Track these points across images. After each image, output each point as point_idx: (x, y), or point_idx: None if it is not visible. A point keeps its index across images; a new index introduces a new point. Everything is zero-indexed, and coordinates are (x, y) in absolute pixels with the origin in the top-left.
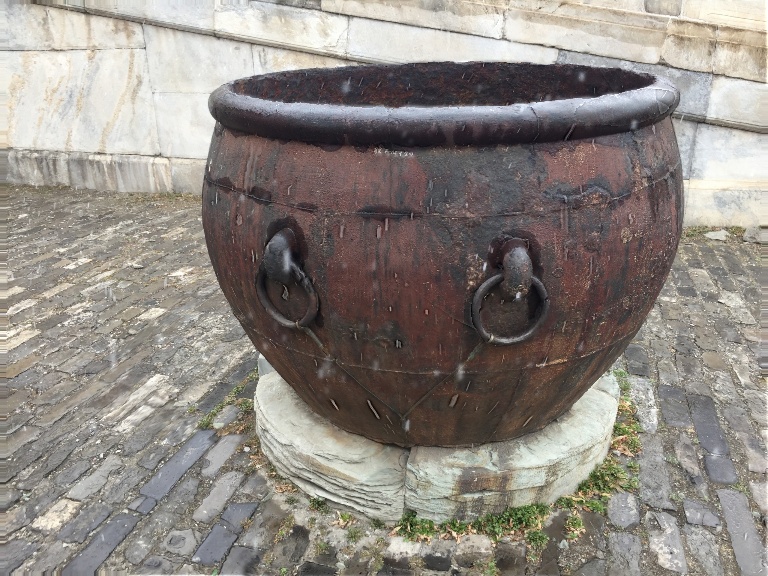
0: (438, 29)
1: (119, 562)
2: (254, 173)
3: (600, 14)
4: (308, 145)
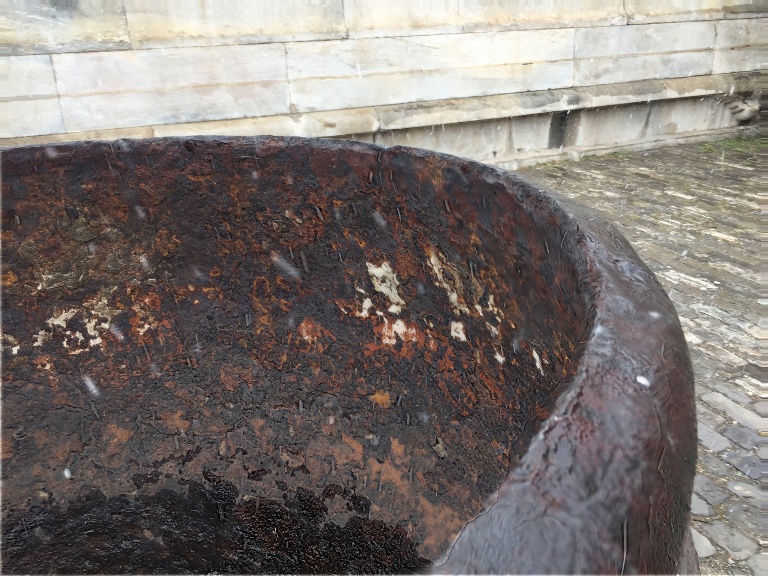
0: None
1: None
2: None
3: None
4: None
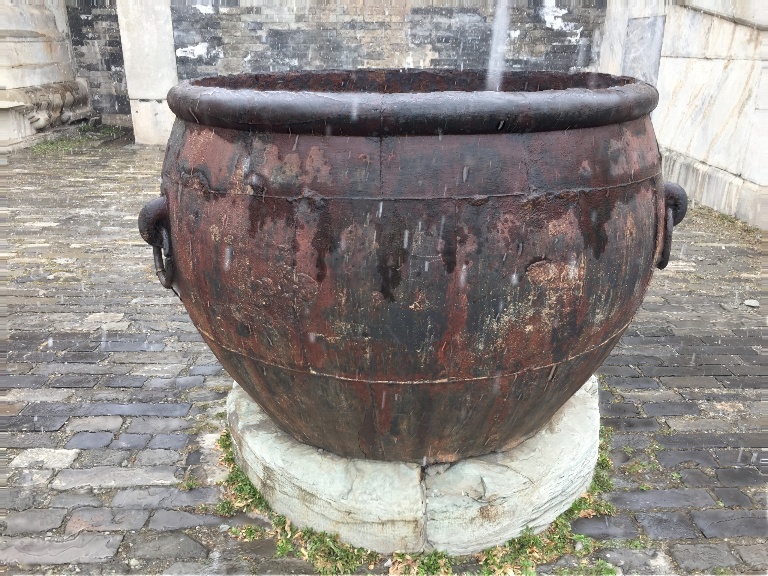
0: None
1: None
2: None
3: None
4: None
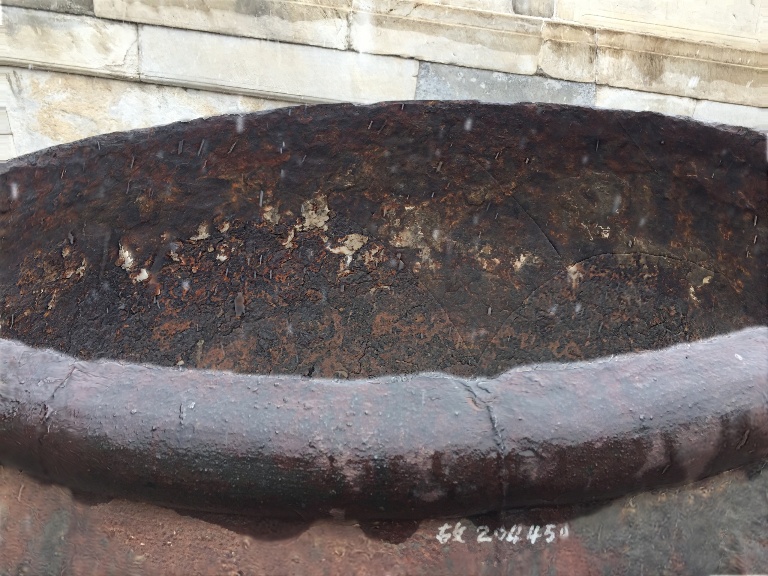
0: (263, 39)
1: None
2: None
3: (464, 17)
4: (182, 518)
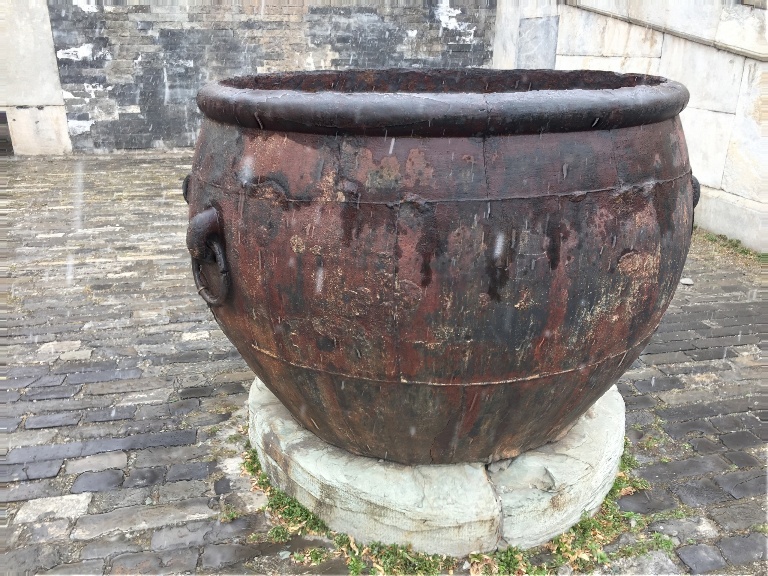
0: None
1: (167, 369)
2: None
3: None
4: None
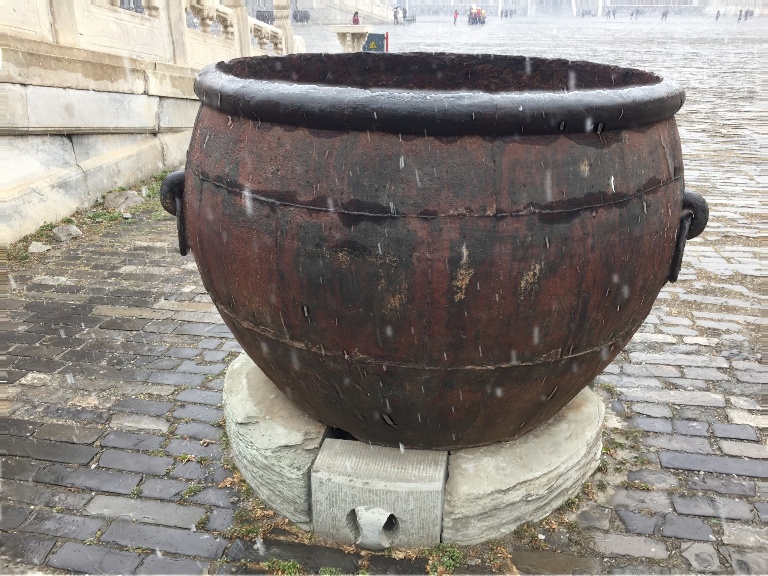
0: None
1: None
2: (672, 156)
3: None
4: None
